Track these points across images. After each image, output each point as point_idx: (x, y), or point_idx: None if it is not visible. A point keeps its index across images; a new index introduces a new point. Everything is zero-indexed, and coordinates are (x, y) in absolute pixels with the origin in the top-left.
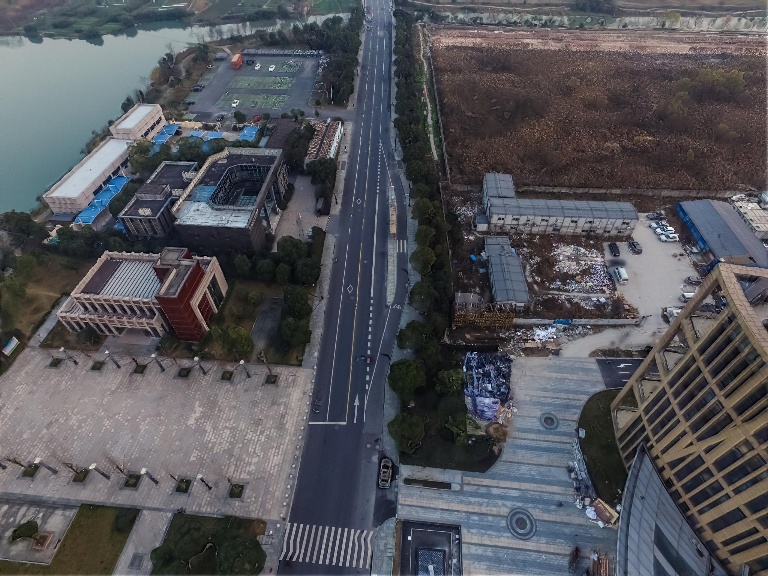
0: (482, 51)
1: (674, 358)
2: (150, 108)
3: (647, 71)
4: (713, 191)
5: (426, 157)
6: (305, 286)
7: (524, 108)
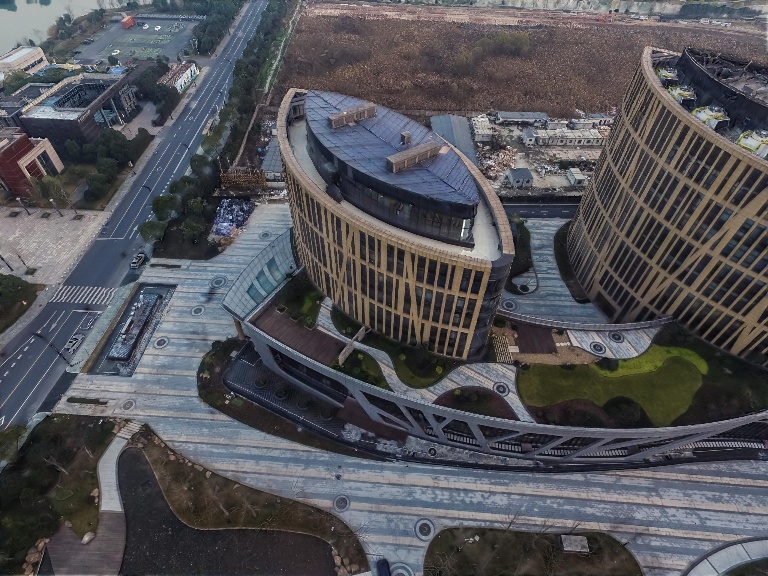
0: (343, 19)
1: None
2: (31, 49)
3: (469, 35)
4: (462, 111)
5: (258, 90)
6: (123, 165)
7: (348, 57)
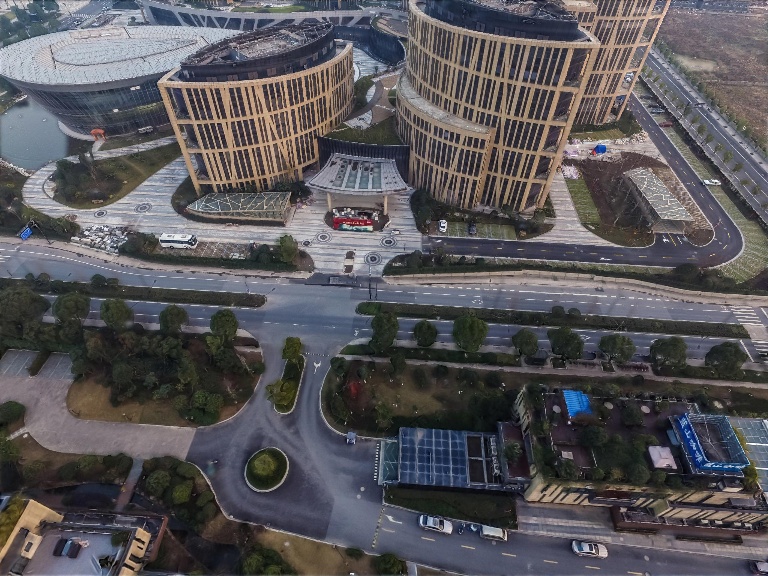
0: None
1: None
2: None
3: None
4: None
5: None
6: None
7: None
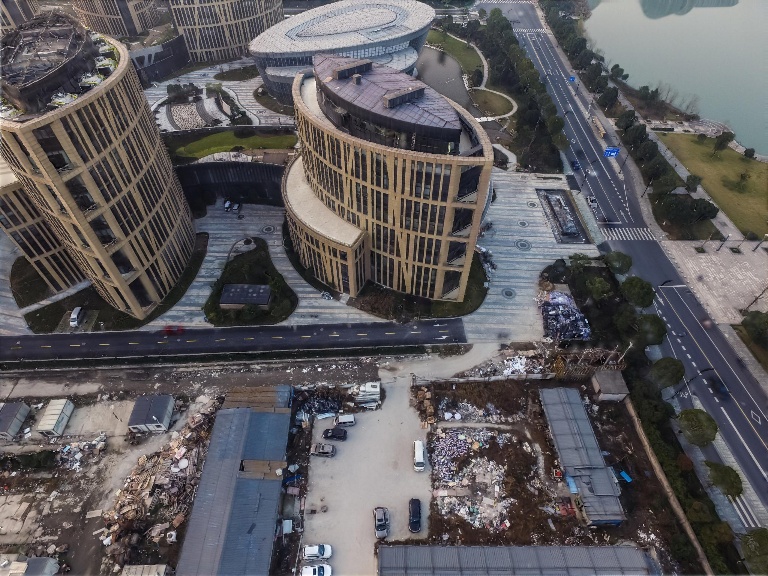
0: None
1: (466, 231)
2: None
3: None
4: None
5: None
6: None
7: None
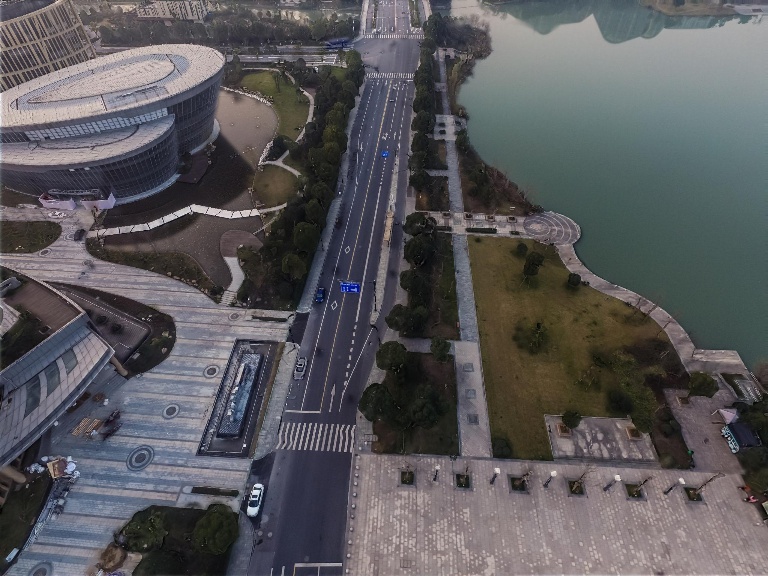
0: None
1: None
2: None
3: None
4: None
5: None
6: None
7: None
